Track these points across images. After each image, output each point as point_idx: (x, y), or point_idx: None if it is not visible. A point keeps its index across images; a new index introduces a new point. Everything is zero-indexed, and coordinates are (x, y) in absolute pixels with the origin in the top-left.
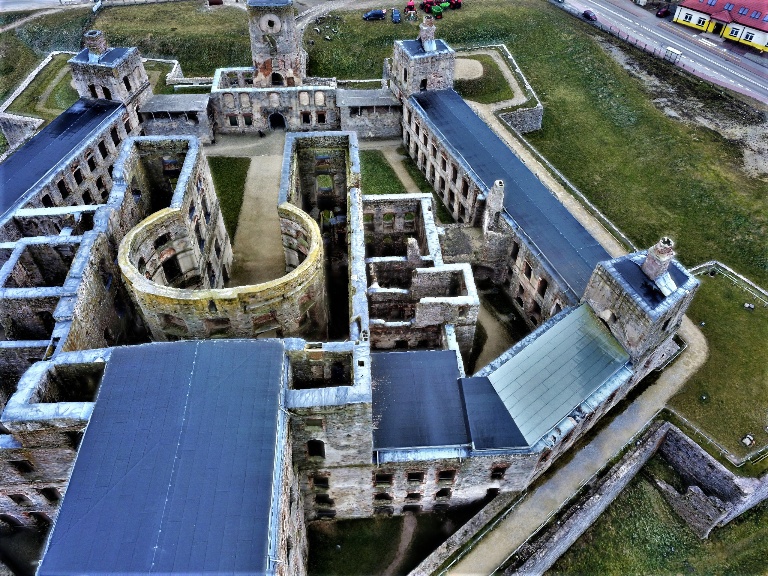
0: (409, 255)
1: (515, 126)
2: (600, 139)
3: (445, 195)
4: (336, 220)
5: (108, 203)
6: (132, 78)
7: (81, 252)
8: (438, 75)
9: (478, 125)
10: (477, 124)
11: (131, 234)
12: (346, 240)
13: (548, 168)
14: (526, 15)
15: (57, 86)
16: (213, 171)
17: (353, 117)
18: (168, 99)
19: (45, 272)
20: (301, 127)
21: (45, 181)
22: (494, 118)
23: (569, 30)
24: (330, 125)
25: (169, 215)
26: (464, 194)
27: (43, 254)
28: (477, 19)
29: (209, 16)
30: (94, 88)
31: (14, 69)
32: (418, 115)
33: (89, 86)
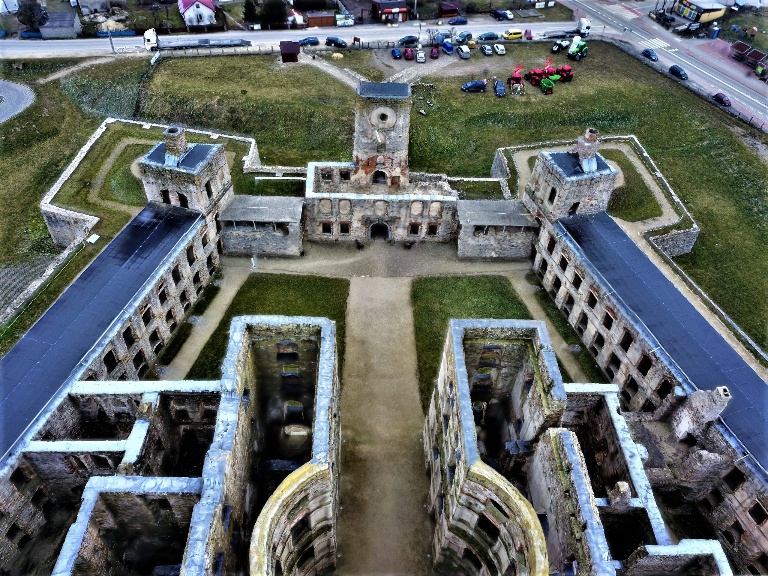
0: (615, 502)
1: (665, 250)
2: (766, 271)
3: (602, 355)
4: (517, 447)
5: (217, 433)
6: (215, 182)
7: (192, 555)
8: (593, 198)
9: (652, 273)
10: (650, 271)
11: (265, 522)
12: (523, 469)
13: (727, 323)
14: (647, 94)
15: (113, 167)
16: (305, 297)
17: (476, 235)
18: (253, 203)
19: (118, 515)
20: (407, 238)
21: (109, 335)
22: (645, 243)
23: (701, 117)
24: (442, 237)
25: (313, 476)
26: (640, 368)
27: (120, 500)
28: (592, 97)
29: (283, 76)
30: (168, 193)
31: (58, 131)
32: (570, 249)
33: (162, 191)
